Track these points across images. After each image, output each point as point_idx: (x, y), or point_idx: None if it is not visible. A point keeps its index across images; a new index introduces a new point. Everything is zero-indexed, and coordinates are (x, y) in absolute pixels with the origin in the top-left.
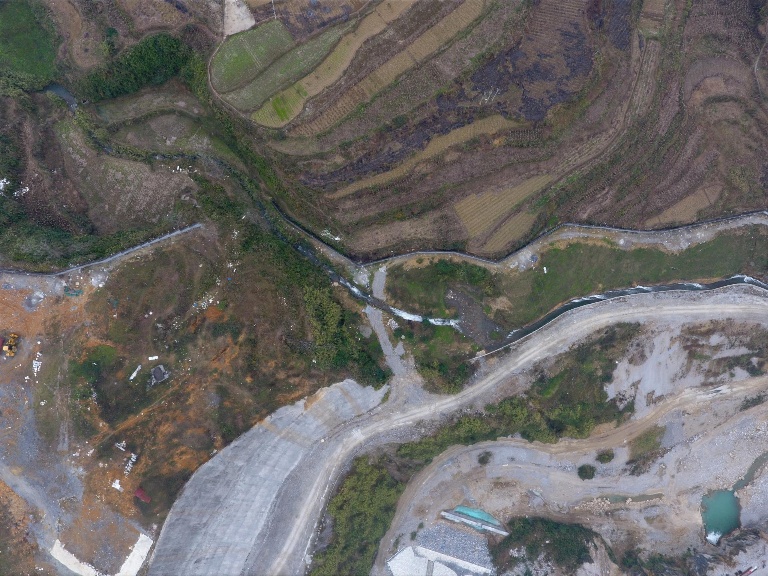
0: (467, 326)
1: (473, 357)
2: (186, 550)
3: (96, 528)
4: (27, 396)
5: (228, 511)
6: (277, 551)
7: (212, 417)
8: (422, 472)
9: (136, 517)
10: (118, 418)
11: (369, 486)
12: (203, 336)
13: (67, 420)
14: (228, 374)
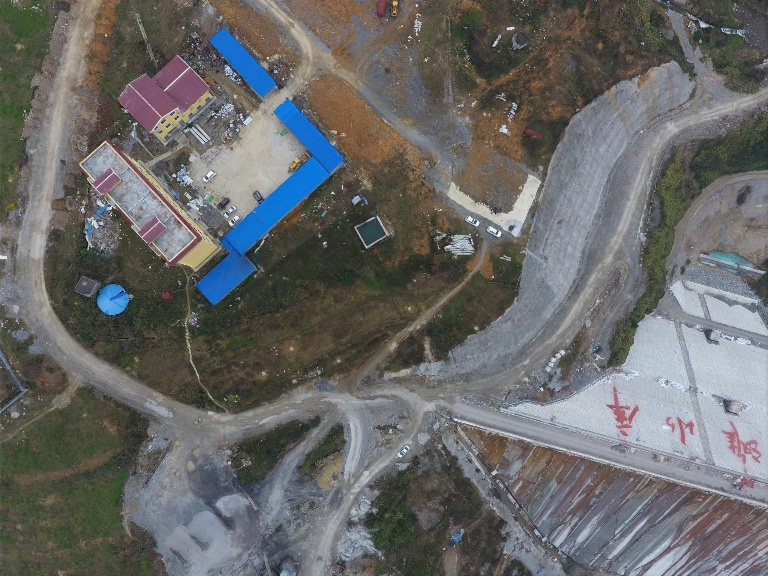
0: (752, 36)
1: (763, 62)
2: (555, 206)
3: (487, 171)
4: (411, 54)
5: (580, 179)
6: (613, 230)
7: (571, 80)
8: (692, 203)
9: (523, 160)
10: (493, 74)
11: (676, 185)
12: (554, 8)
13: (450, 75)
14: (580, 42)
